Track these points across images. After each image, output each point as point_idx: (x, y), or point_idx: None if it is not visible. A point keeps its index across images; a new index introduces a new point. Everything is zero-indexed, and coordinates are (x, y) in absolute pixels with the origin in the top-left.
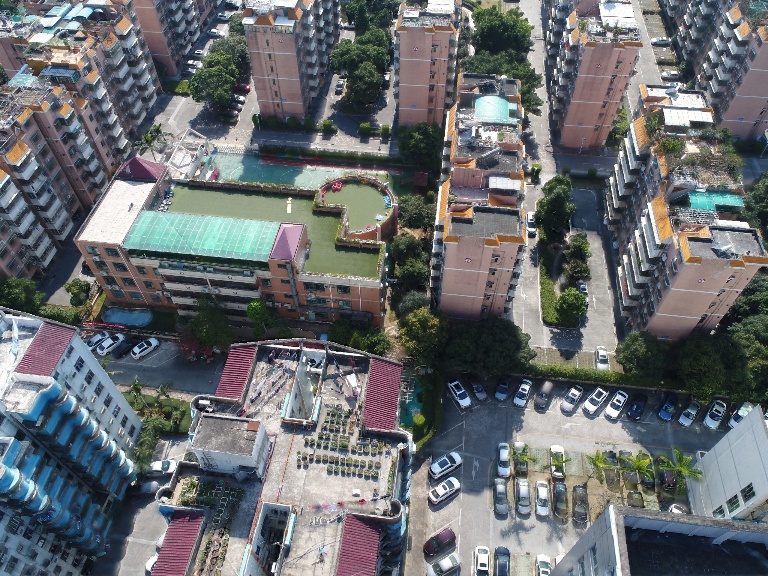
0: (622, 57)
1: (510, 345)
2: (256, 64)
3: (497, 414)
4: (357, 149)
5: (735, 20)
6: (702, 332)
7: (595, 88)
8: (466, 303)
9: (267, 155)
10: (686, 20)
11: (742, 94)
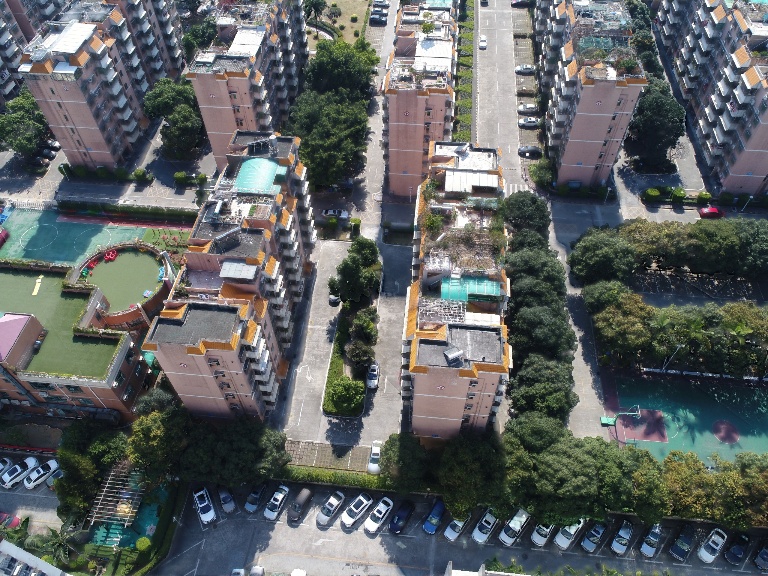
0: (431, 104)
1: (247, 455)
2: (48, 113)
3: (243, 529)
4: (169, 202)
5: (567, 57)
6: (474, 430)
7: (410, 136)
8: (209, 403)
9: (68, 211)
10: (543, 49)
11: (574, 138)
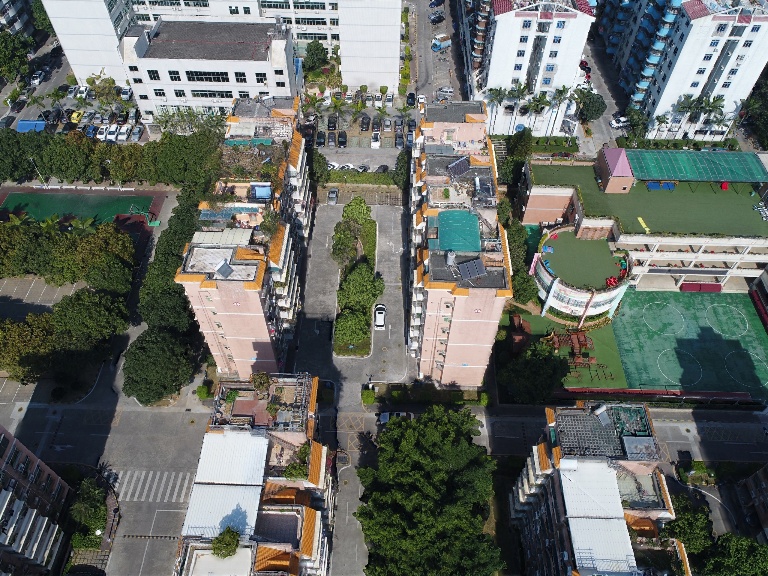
0: None
1: None
2: None
3: None
4: None
5: None
6: None
7: None
8: None
9: None
10: None
11: None
